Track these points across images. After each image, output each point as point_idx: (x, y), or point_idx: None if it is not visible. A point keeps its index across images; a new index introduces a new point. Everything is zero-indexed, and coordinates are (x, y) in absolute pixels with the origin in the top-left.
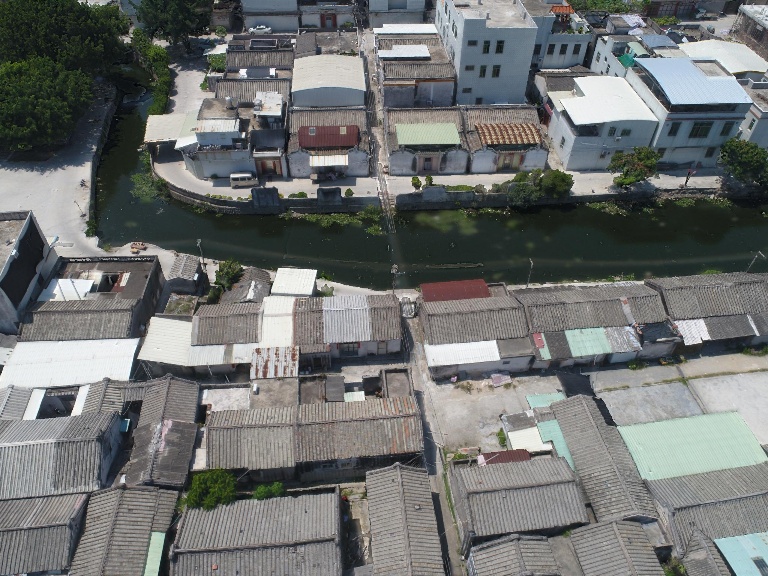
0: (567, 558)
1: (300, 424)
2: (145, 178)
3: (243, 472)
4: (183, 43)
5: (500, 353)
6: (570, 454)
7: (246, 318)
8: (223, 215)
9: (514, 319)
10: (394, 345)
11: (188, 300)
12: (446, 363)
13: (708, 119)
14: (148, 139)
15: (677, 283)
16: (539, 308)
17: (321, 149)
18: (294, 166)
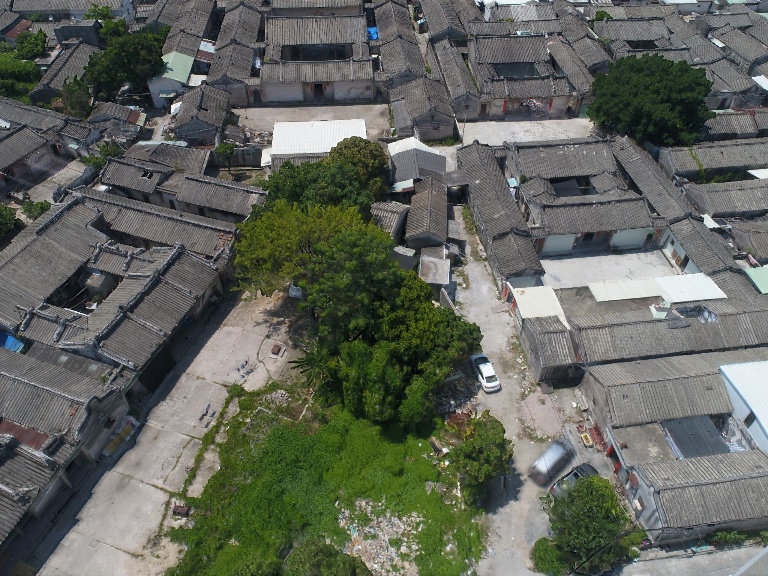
0: None
1: (627, 6)
2: None
3: None
4: None
5: (697, 0)
6: None
7: None
8: None
9: None
10: (644, 3)
11: None
12: None
13: None
14: None
15: None
16: None
17: None
18: None
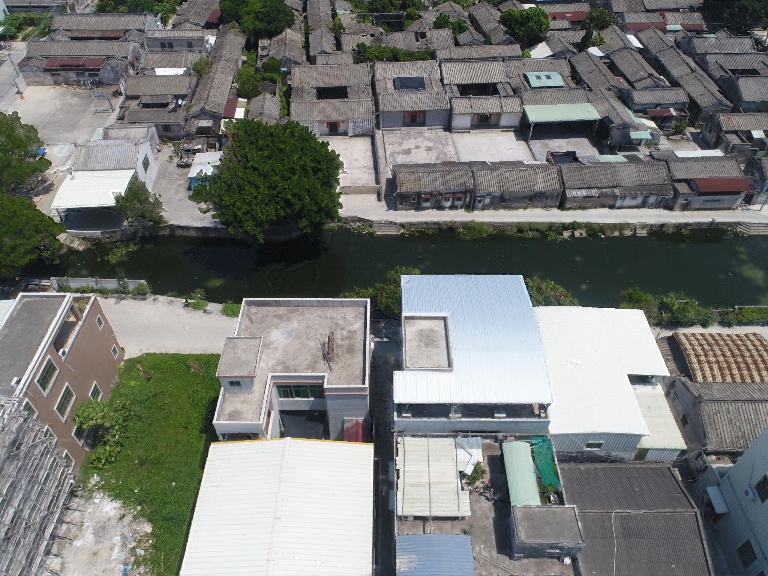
0: None
1: None
2: None
3: None
4: None
5: None
6: None
7: None
8: None
9: None
10: None
11: None
12: None
13: None
14: None
15: (542, 176)
16: None
17: None
18: None
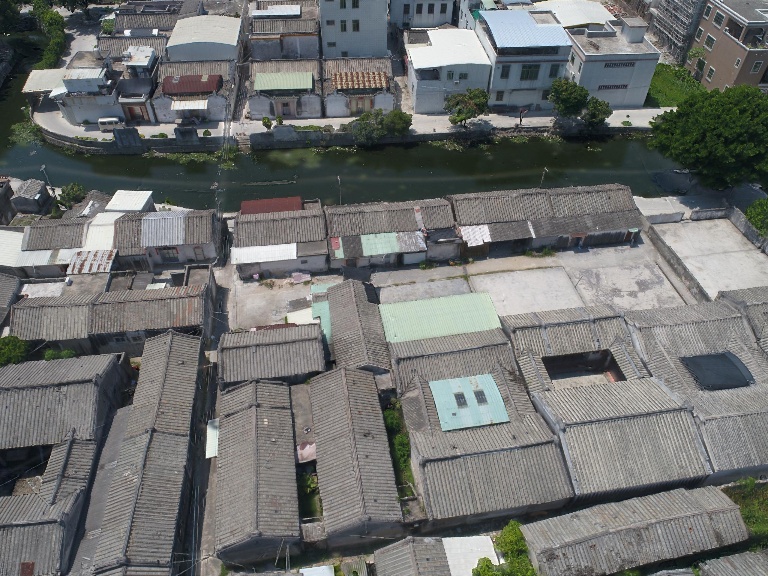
0: (303, 399)
1: (95, 303)
2: (25, 126)
3: (41, 343)
4: (82, 10)
5: (297, 253)
6: (331, 325)
7: (73, 227)
8: (91, 155)
9: (315, 225)
10: (209, 251)
11: (31, 218)
12: (247, 261)
13: (534, 62)
14: (26, 90)
15: (471, 196)
16: (339, 216)
17: (183, 95)
18: (160, 111)
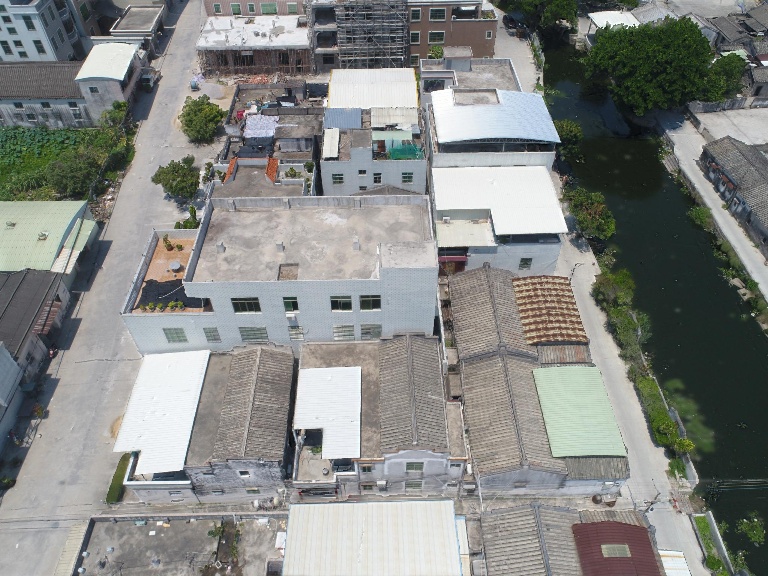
0: None
1: None
2: None
3: None
4: None
5: None
6: None
7: None
8: None
9: None
10: None
11: None
12: None
13: None
14: None
15: None
16: None
17: None
18: None
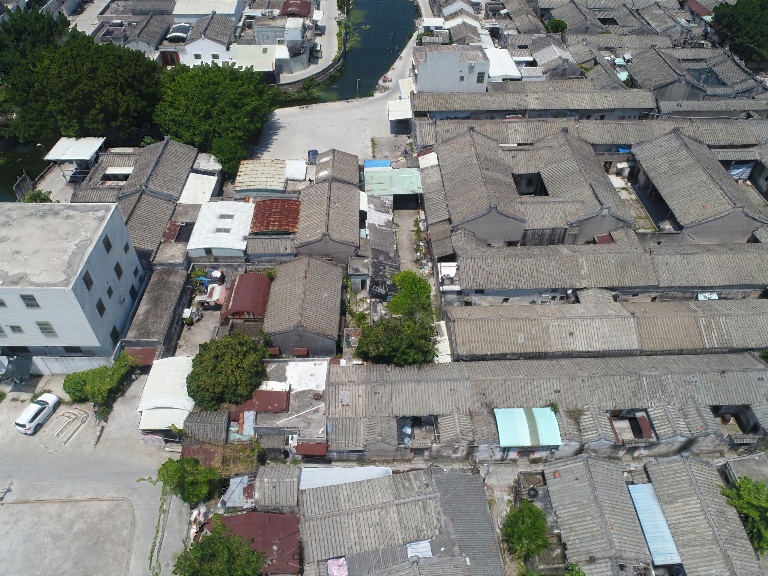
0: None
1: None
2: None
3: None
4: None
5: None
6: None
7: None
8: None
9: None
10: None
11: None
12: None
13: None
14: (270, 69)
15: None
16: None
17: None
18: None
